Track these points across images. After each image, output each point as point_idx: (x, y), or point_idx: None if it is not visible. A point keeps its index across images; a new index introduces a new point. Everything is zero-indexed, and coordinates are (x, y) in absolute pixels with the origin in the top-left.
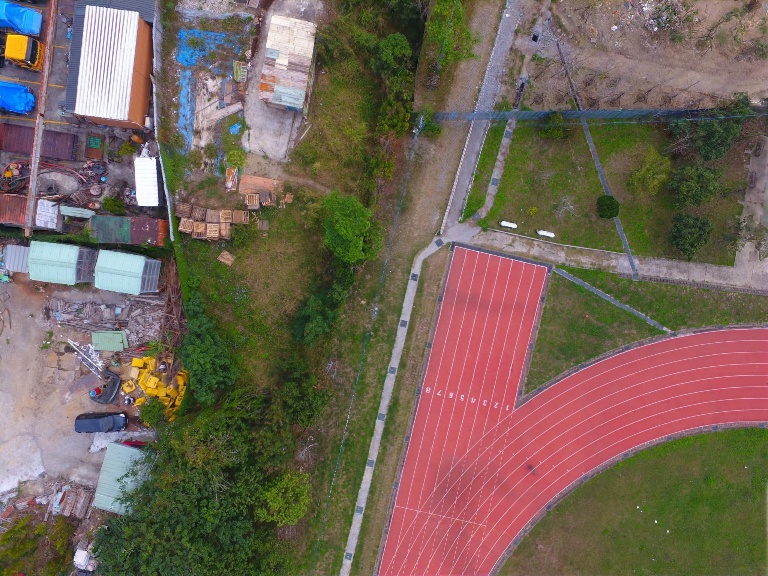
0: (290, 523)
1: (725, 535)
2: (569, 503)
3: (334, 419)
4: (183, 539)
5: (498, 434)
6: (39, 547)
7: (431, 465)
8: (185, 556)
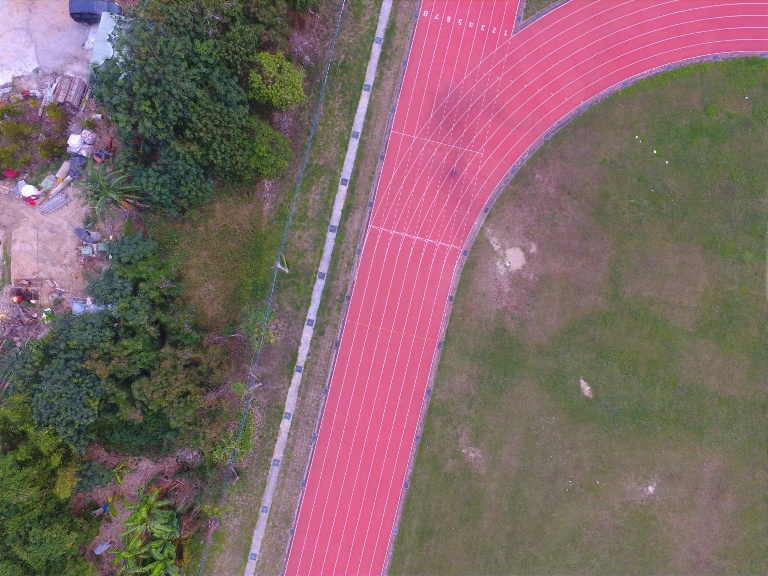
0: (285, 96)
1: (725, 167)
2: (567, 132)
3: (330, 40)
4: (176, 47)
5: (496, 60)
6: (33, 143)
7: (428, 91)
8: (178, 72)
